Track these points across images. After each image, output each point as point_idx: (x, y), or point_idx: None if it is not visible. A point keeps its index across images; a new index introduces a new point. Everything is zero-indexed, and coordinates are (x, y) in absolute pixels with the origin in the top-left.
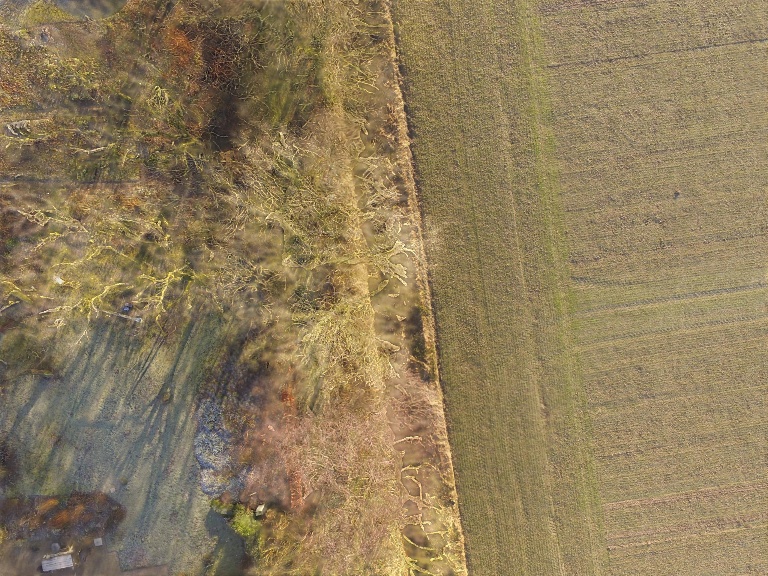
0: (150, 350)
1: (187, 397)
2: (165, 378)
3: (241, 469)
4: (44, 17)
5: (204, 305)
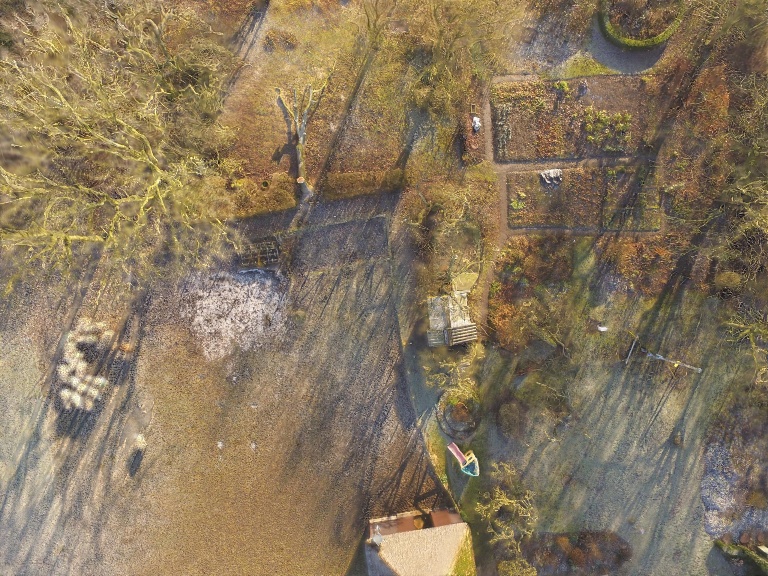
0: (662, 394)
1: (696, 441)
2: (676, 422)
3: (743, 511)
4: (583, 69)
5: (713, 352)
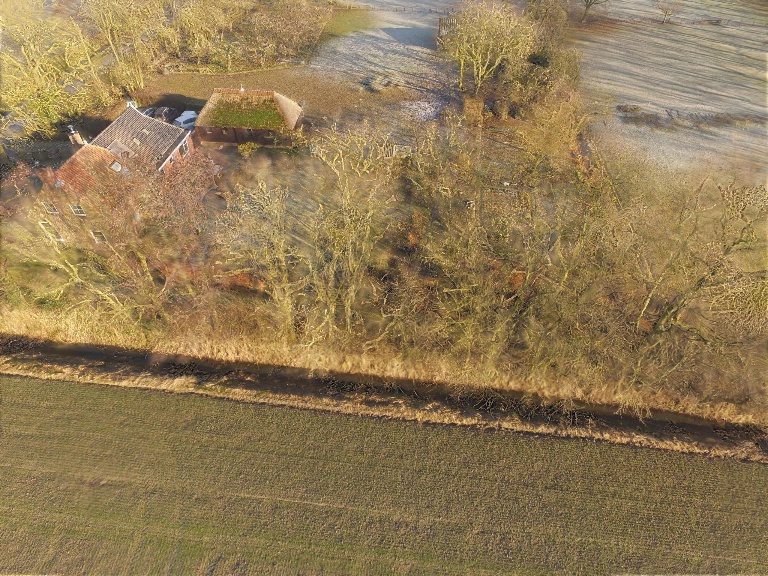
0: None
1: None
2: (293, 231)
3: None
4: None
5: None
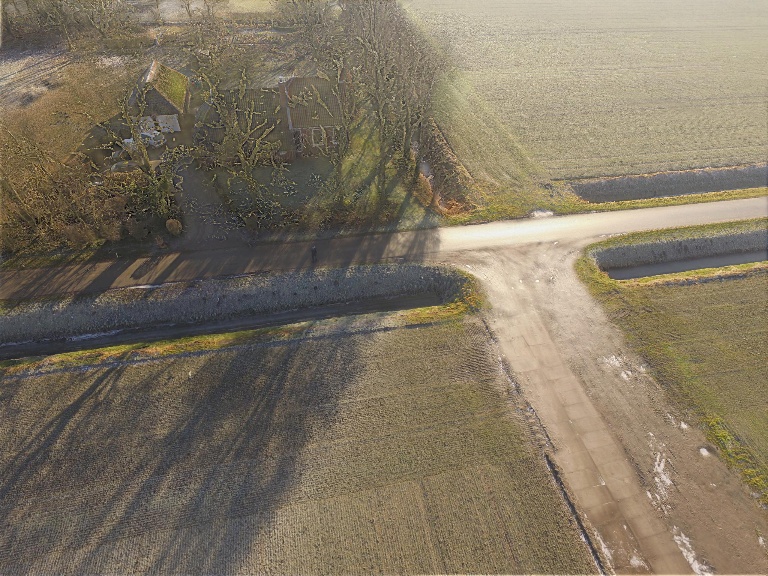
0: None
1: None
2: None
3: None
4: None
5: None
